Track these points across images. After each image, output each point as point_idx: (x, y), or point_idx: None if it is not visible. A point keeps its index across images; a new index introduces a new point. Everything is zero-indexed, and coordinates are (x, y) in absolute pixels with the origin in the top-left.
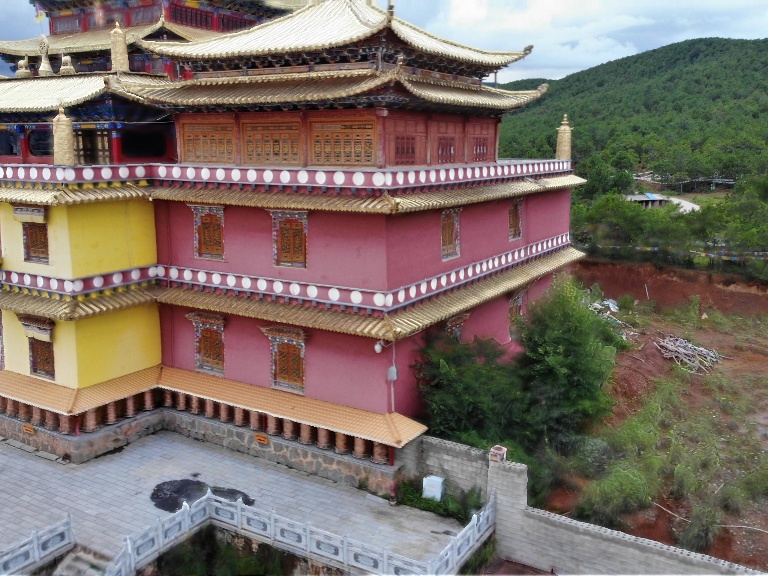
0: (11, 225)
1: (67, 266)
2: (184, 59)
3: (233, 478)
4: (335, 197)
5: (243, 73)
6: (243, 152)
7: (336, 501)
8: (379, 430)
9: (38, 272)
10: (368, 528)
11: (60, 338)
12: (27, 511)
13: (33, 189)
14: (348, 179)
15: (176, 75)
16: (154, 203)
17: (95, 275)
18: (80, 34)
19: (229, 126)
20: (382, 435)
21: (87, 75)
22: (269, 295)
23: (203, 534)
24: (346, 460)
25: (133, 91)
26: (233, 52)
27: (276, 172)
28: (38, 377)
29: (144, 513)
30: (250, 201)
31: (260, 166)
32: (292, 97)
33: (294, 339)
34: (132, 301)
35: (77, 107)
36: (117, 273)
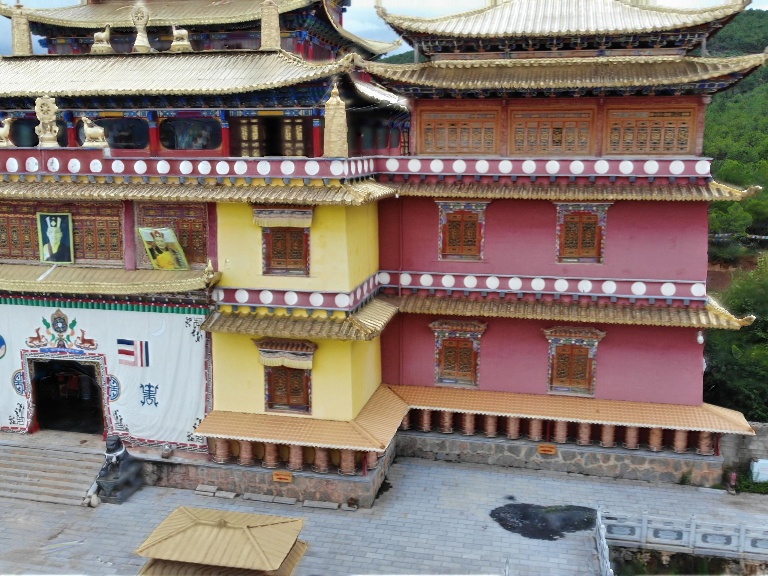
0: (240, 232)
1: (342, 277)
2: (430, 38)
3: (552, 494)
4: (652, 187)
5: (506, 56)
6: (510, 142)
7: (680, 499)
8: (716, 421)
9: (288, 287)
10: (749, 519)
11: (325, 363)
12: (400, 569)
13: (289, 187)
14: (663, 168)
15: (305, 57)
16: (379, 201)
17: (357, 286)
18: (146, 4)
19: (491, 113)
20: (725, 425)
21: (226, 53)
22: (549, 295)
23: (609, 556)
24: (662, 457)
25: (378, 72)
26: (515, 32)
27: (564, 162)
28: (280, 413)
29: (527, 546)
30: (550, 194)
31: (540, 156)
32: (614, 82)
33: (586, 339)
34: (390, 313)
35: (274, 90)
36: (365, 282)
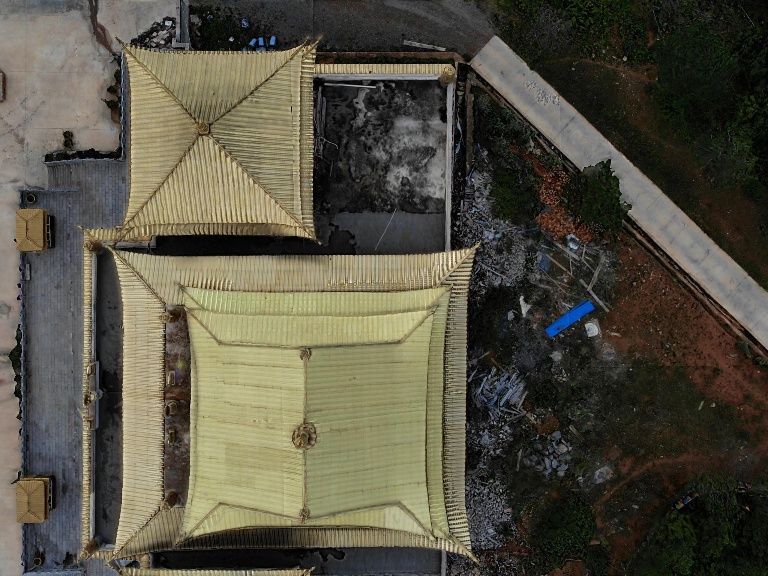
0: None
1: None
2: None
3: None
4: None
5: None
6: None
7: None
8: None
9: None
10: None
11: None
12: None
13: None
14: None
15: None
16: None
17: None
18: None
19: None
20: None
21: None
22: None
23: None
24: None
25: None
26: None
27: None
28: None
29: (114, 575)
30: None
31: None
32: None
33: None
34: None
35: None
36: None
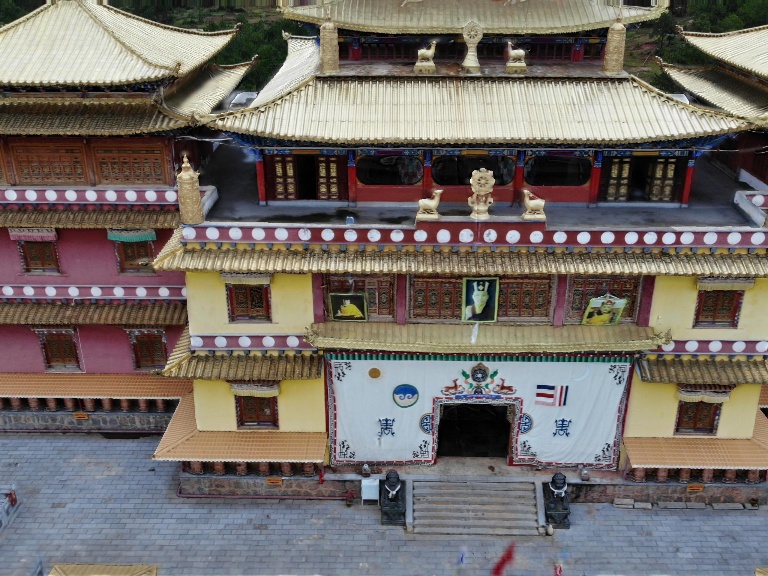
0: (676, 293)
1: (766, 328)
2: None
3: None
4: None
5: None
6: None
7: None
8: None
9: (715, 337)
10: None
11: (737, 396)
12: None
13: (734, 255)
14: None
15: None
16: None
17: None
18: None
19: None
20: None
21: (574, 79)
22: None
23: None
24: None
25: None
26: None
27: None
28: (687, 436)
29: None
30: None
31: None
32: None
33: None
34: None
35: None
36: None
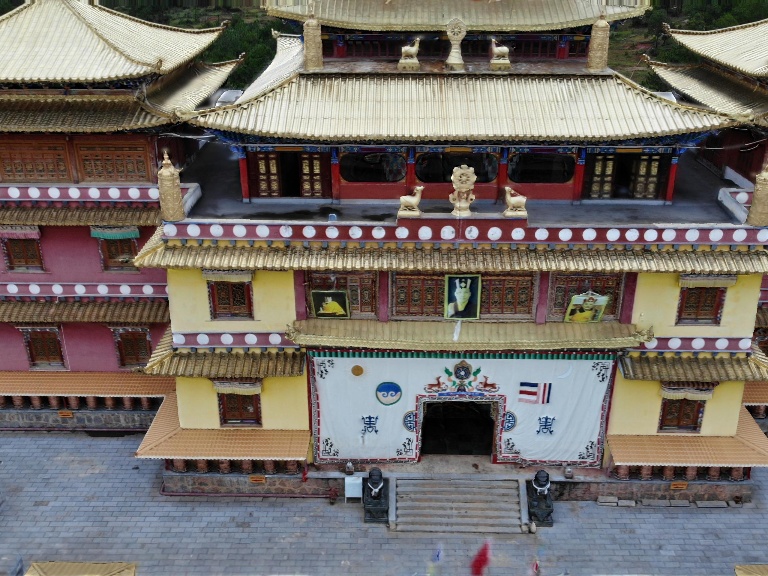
0: (659, 290)
1: (749, 325)
2: None
3: None
4: None
5: None
6: None
7: None
8: None
9: (698, 334)
10: None
11: (720, 393)
12: None
13: (716, 252)
14: None
15: None
16: None
17: None
18: None
19: None
20: None
21: (557, 76)
22: None
23: None
24: None
25: (763, 123)
26: None
27: None
28: (671, 434)
29: None
30: None
31: None
32: None
33: None
34: None
35: None
36: None
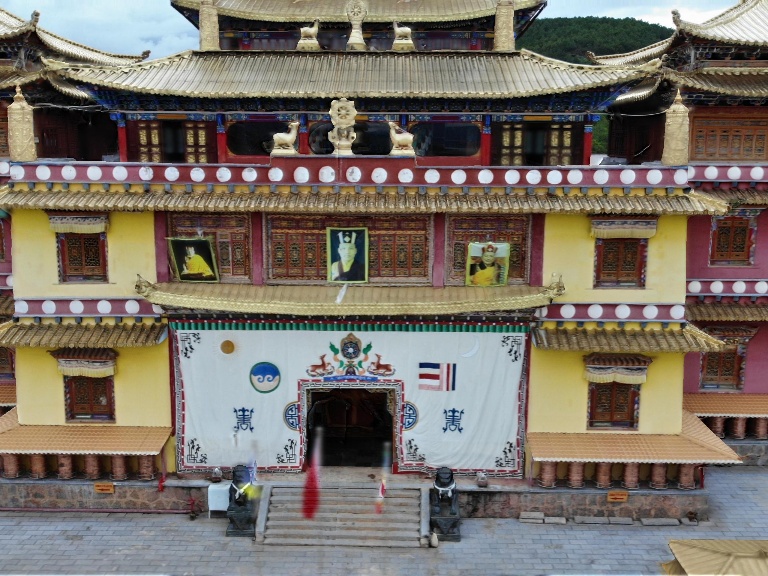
0: (570, 244)
1: (679, 288)
2: (709, 44)
3: None
4: None
5: None
6: None
7: None
8: None
9: (621, 300)
10: None
11: (656, 377)
12: None
13: (630, 196)
14: None
15: None
16: None
17: None
18: None
19: (764, 121)
20: None
21: (462, 54)
22: None
23: None
24: None
25: (674, 78)
26: None
27: None
28: (604, 431)
29: None
30: None
31: None
32: None
33: None
34: None
35: None
36: None
